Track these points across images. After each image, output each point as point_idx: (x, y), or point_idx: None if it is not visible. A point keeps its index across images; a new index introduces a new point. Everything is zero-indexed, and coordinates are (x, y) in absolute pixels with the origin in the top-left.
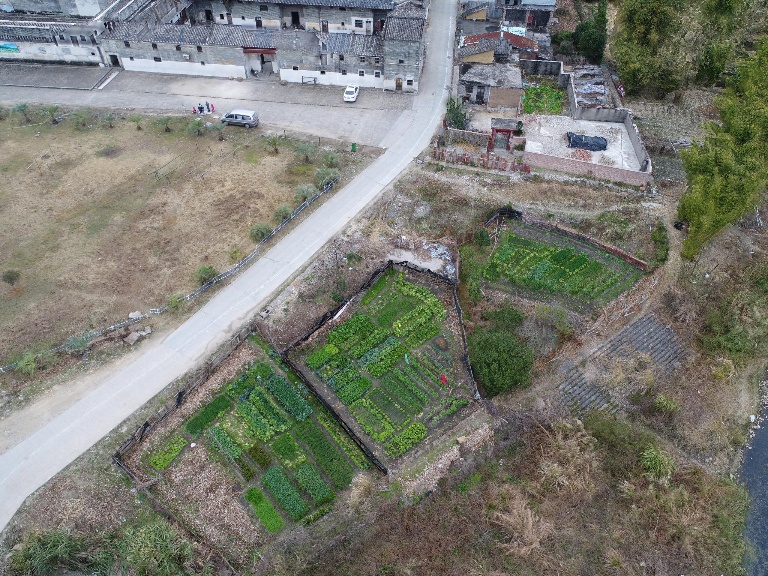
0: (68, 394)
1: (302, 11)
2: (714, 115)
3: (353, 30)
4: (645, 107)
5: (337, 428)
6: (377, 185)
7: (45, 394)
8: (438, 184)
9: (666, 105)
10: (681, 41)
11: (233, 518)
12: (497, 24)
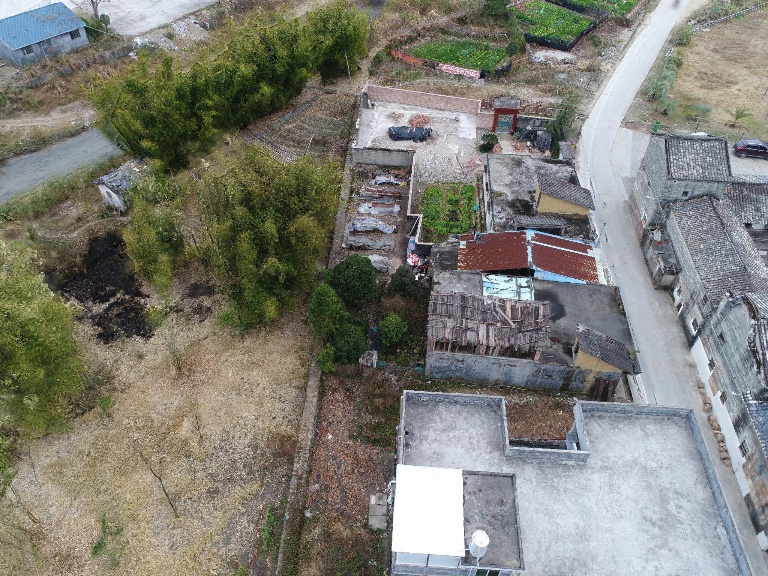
0: (697, 3)
1: None
2: None
3: None
4: None
5: None
6: (610, 93)
7: (707, 2)
8: (556, 86)
9: None
10: None
11: None
12: None
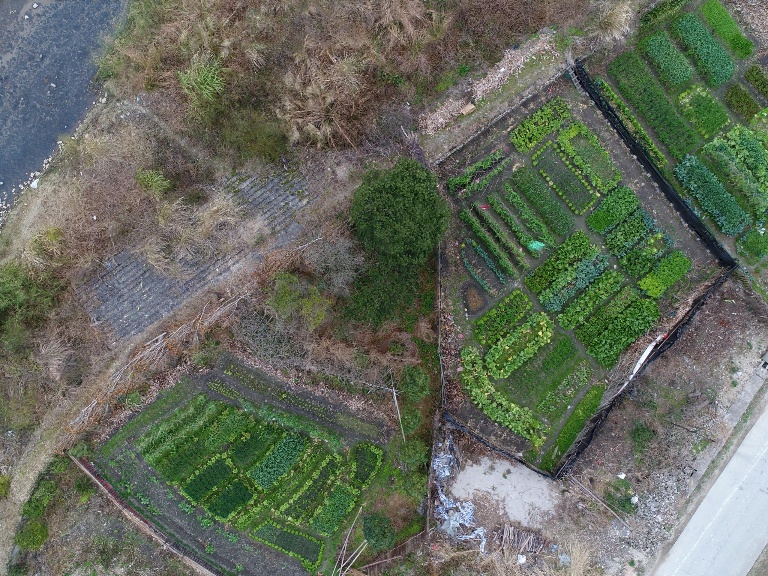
0: None
1: None
2: None
3: None
4: None
5: None
6: None
7: None
8: None
9: None
10: None
11: (765, 17)
12: None
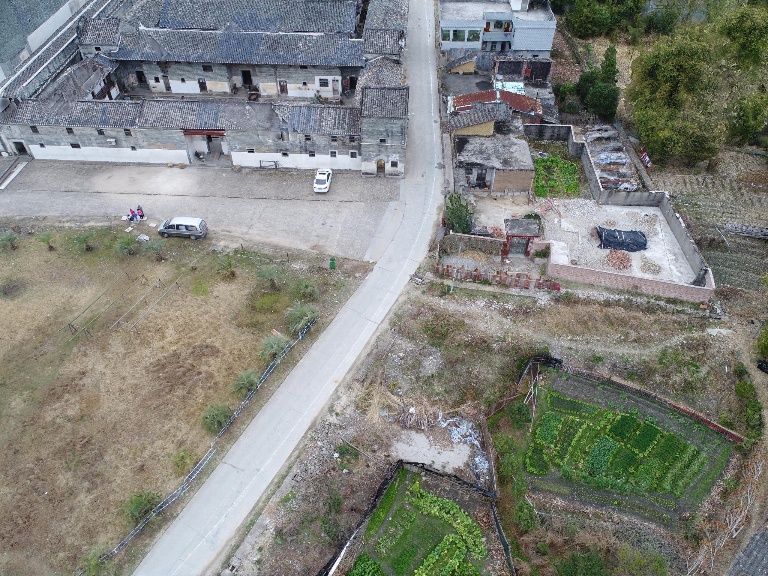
0: None
1: (254, 69)
2: (758, 186)
3: (317, 90)
4: (675, 179)
5: None
6: (368, 324)
7: None
8: (448, 320)
9: (699, 175)
10: (714, 100)
11: None
12: (488, 78)
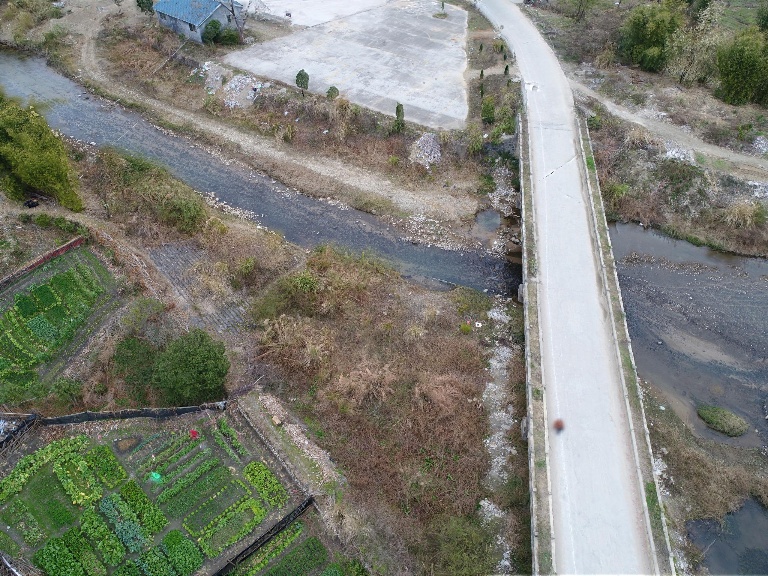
0: None
1: None
2: None
3: None
4: None
5: (241, 570)
6: None
7: None
8: None
9: None
10: None
11: None
12: None
